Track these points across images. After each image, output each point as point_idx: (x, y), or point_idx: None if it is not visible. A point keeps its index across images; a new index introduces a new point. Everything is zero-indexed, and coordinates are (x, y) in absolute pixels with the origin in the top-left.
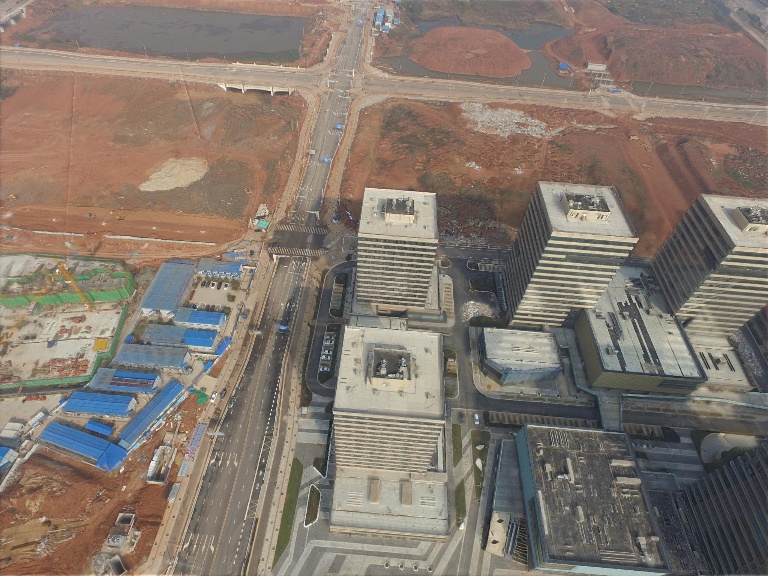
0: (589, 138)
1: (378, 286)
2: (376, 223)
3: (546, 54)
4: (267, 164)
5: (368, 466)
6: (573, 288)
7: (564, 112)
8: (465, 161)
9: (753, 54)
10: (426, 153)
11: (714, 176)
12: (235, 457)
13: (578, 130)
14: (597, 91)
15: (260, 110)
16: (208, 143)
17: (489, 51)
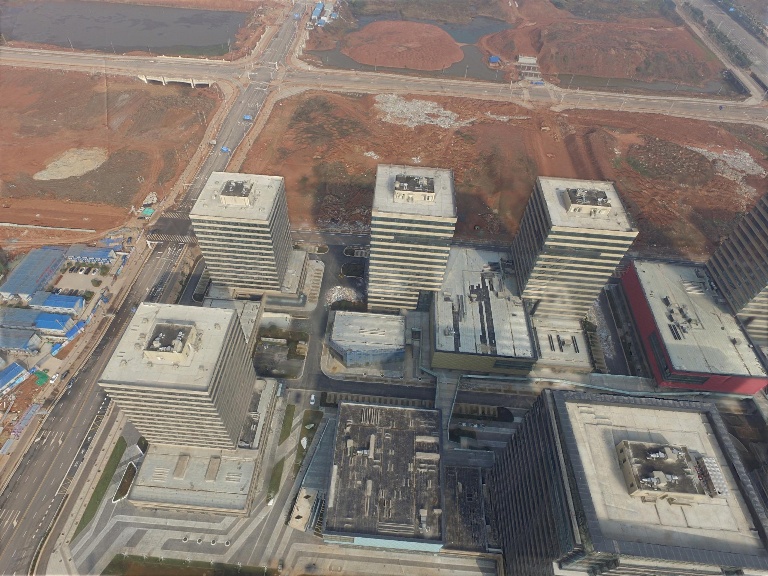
0: (496, 128)
1: (228, 269)
2: (212, 205)
3: (480, 48)
4: (167, 154)
5: (177, 443)
6: (413, 270)
7: (479, 103)
8: (364, 150)
9: (687, 47)
10: (328, 143)
11: (614, 165)
12: (61, 436)
13: (489, 121)
14: (520, 83)
15: (173, 101)
16: (113, 133)
17: (422, 45)
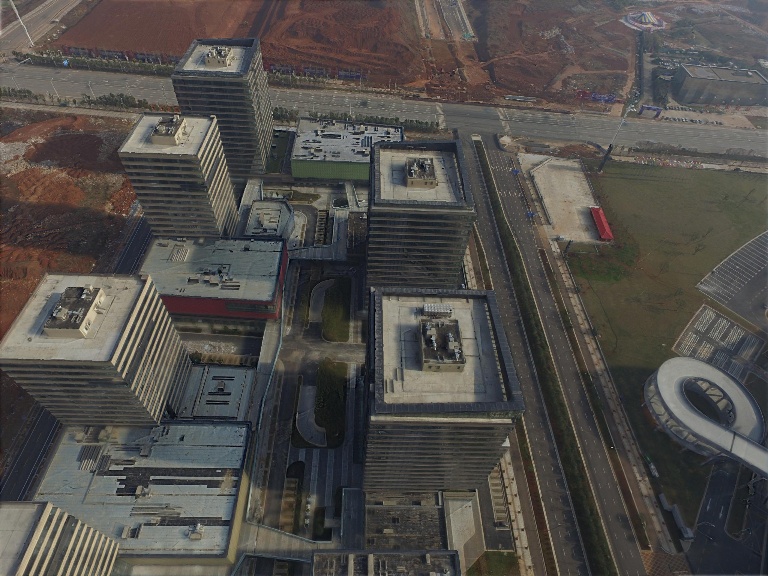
0: None
1: None
2: None
3: None
4: None
5: None
6: None
7: None
8: None
9: None
10: None
11: None
12: None
13: None
14: None
15: None
16: None
17: None
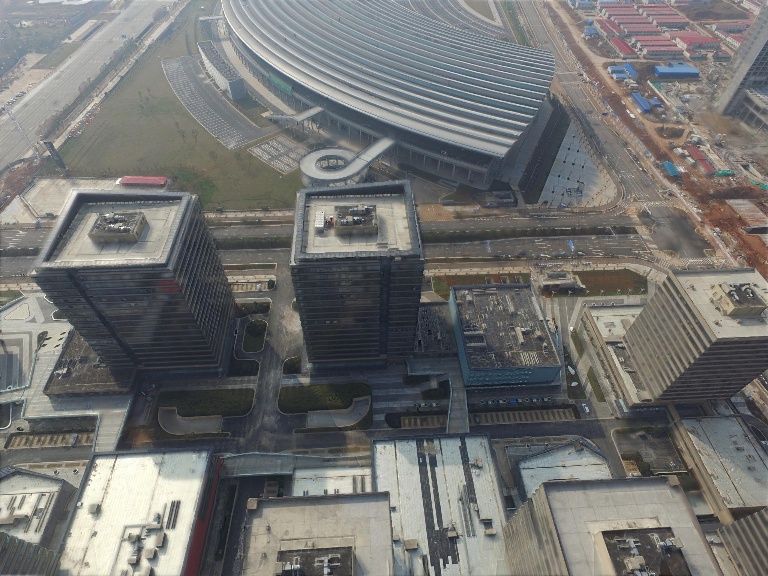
0: None
1: None
2: None
3: None
4: None
5: None
6: None
7: None
8: None
9: None
10: None
11: None
12: None
13: None
14: None
15: None
16: None
17: None
